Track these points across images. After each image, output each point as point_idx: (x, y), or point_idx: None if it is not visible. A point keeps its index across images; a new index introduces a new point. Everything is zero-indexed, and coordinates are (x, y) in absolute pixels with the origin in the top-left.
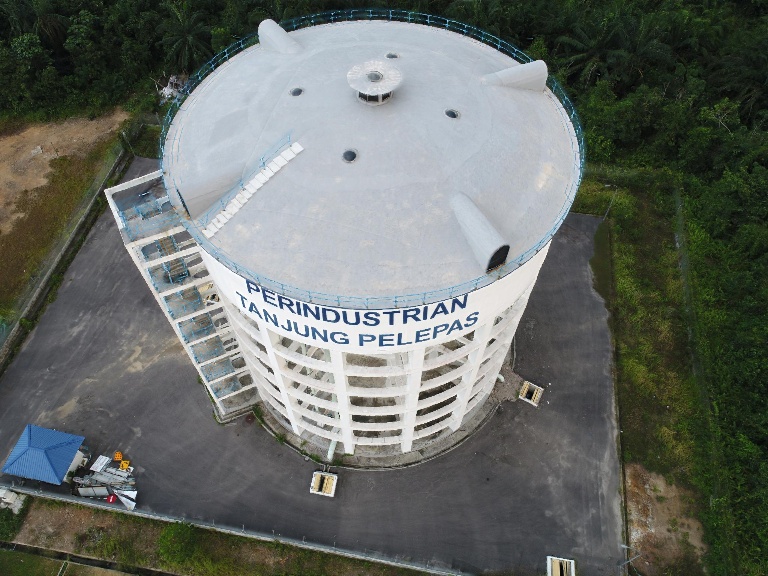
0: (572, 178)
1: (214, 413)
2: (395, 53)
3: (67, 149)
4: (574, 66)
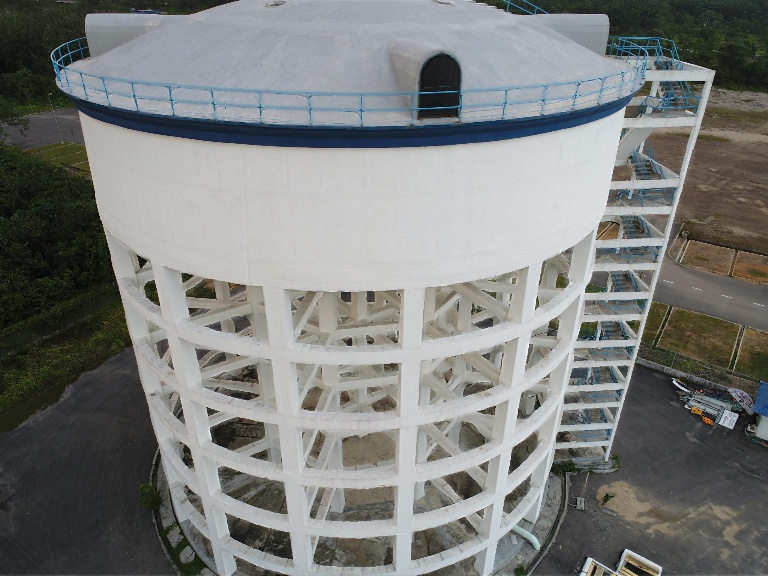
0: None
1: None
2: (267, 6)
3: None
4: None
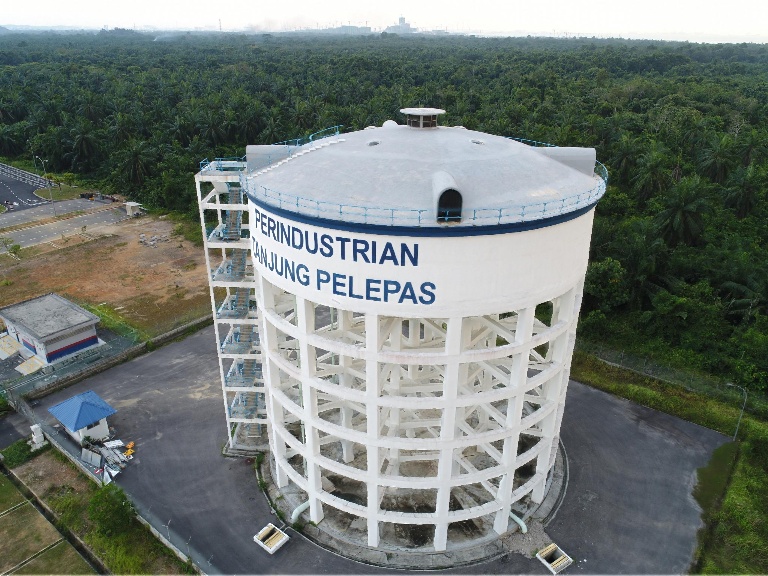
0: (575, 206)
1: (225, 445)
2: None
3: None
4: (740, 309)
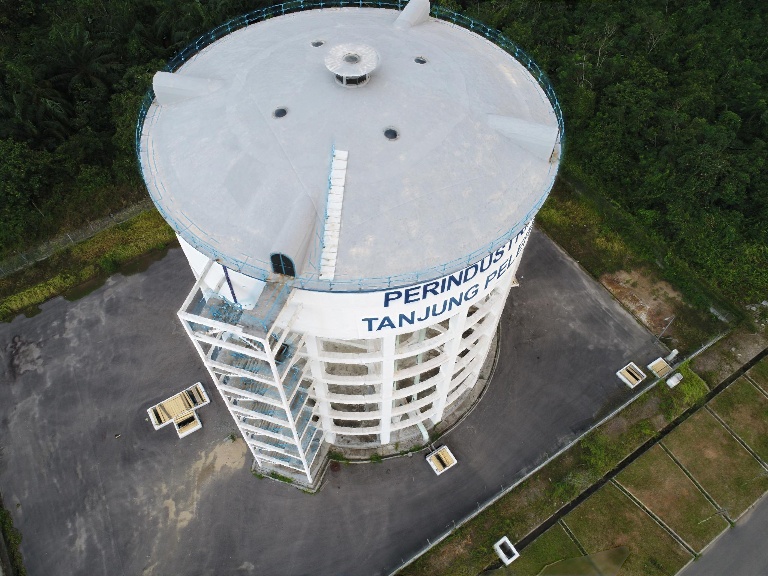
0: (519, 68)
1: (301, 490)
2: (316, 41)
3: None
4: None
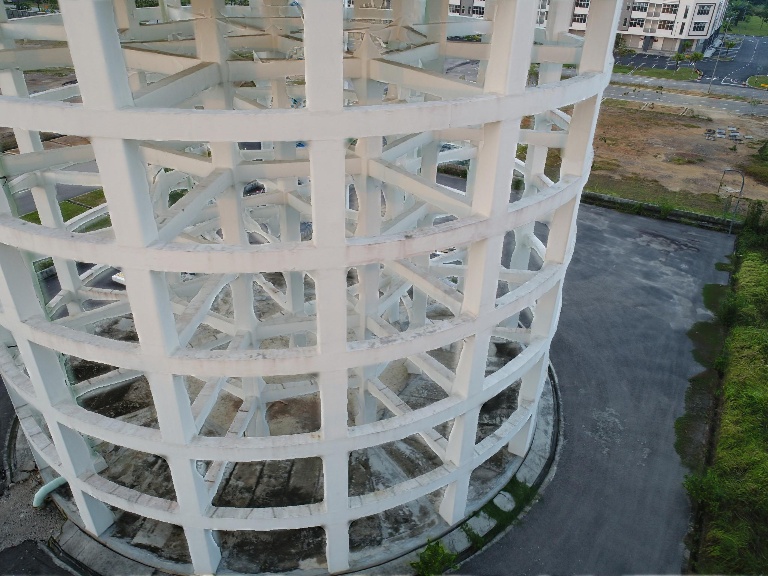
0: None
1: None
2: None
3: (740, 204)
4: None
